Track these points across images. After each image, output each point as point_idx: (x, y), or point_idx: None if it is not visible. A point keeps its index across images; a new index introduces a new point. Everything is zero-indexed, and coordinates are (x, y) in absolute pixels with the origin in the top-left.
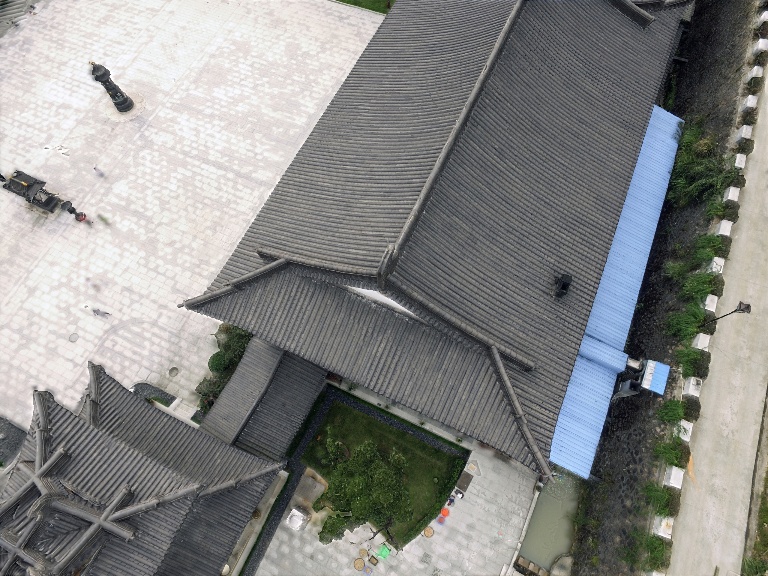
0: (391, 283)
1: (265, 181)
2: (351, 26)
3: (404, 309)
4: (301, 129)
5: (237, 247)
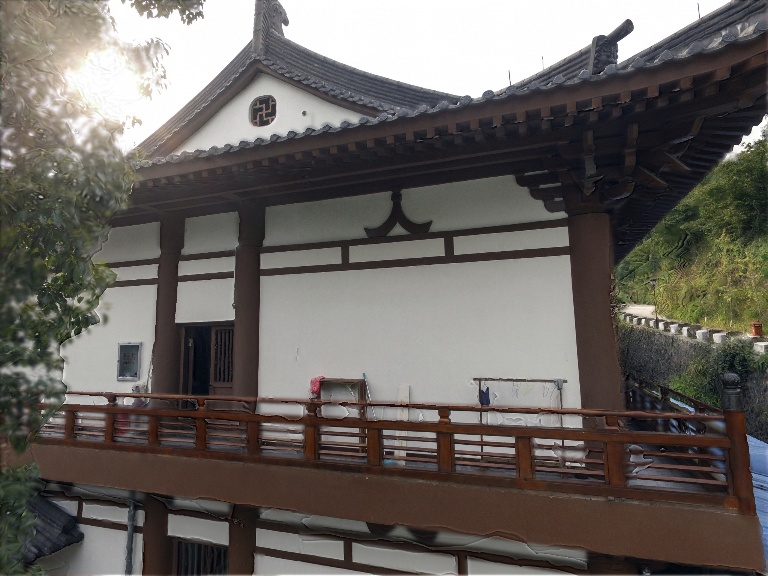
0: (276, 38)
1: None
2: None
3: None
4: None
5: None
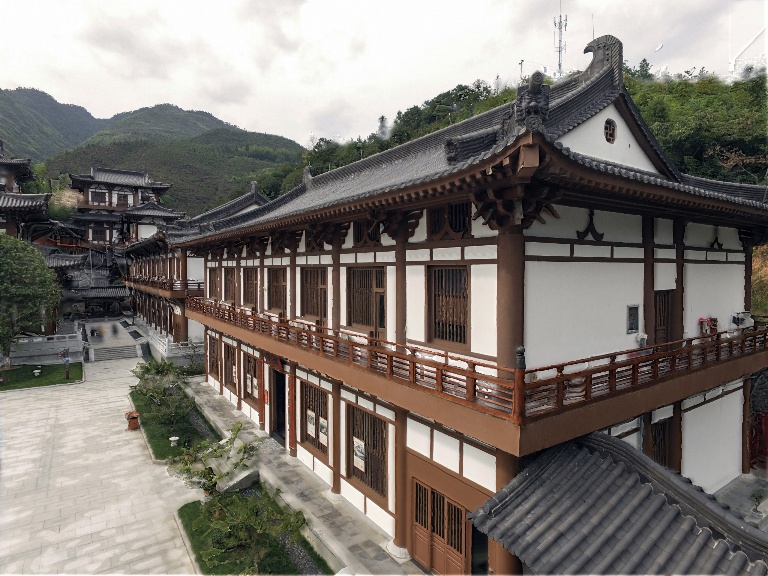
0: None
1: (9, 554)
2: (17, 400)
3: (625, 162)
4: (32, 474)
5: (388, 187)
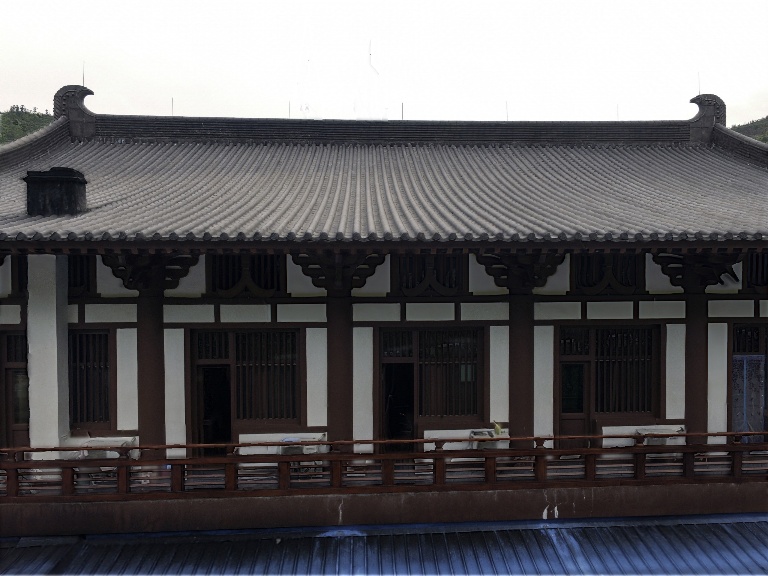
0: None
1: None
2: None
3: None
4: None
5: None
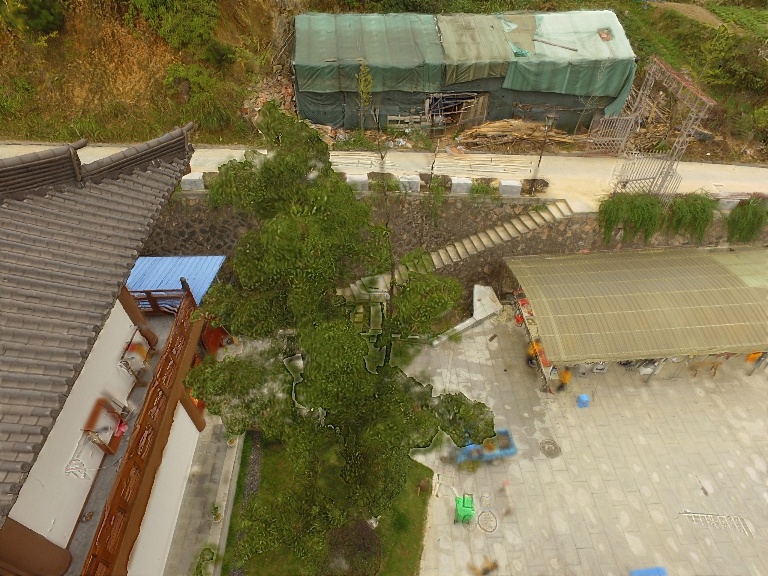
0: None
1: None
2: None
3: None
4: None
5: None
